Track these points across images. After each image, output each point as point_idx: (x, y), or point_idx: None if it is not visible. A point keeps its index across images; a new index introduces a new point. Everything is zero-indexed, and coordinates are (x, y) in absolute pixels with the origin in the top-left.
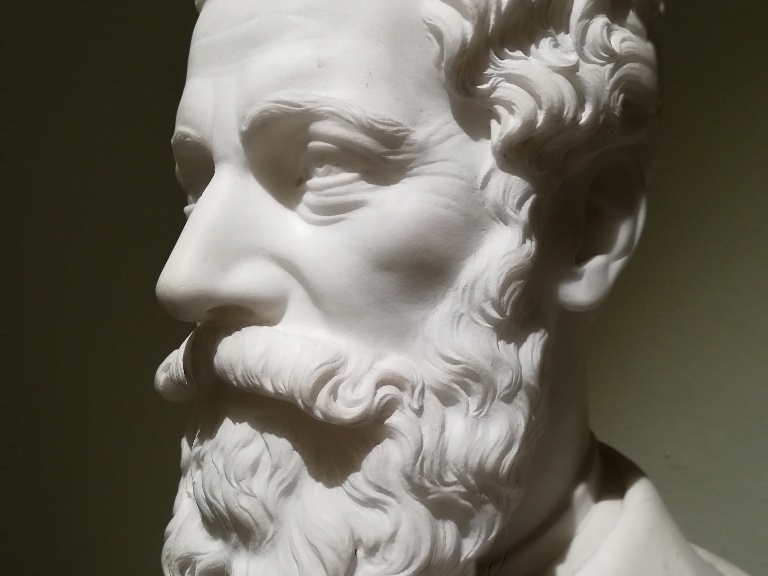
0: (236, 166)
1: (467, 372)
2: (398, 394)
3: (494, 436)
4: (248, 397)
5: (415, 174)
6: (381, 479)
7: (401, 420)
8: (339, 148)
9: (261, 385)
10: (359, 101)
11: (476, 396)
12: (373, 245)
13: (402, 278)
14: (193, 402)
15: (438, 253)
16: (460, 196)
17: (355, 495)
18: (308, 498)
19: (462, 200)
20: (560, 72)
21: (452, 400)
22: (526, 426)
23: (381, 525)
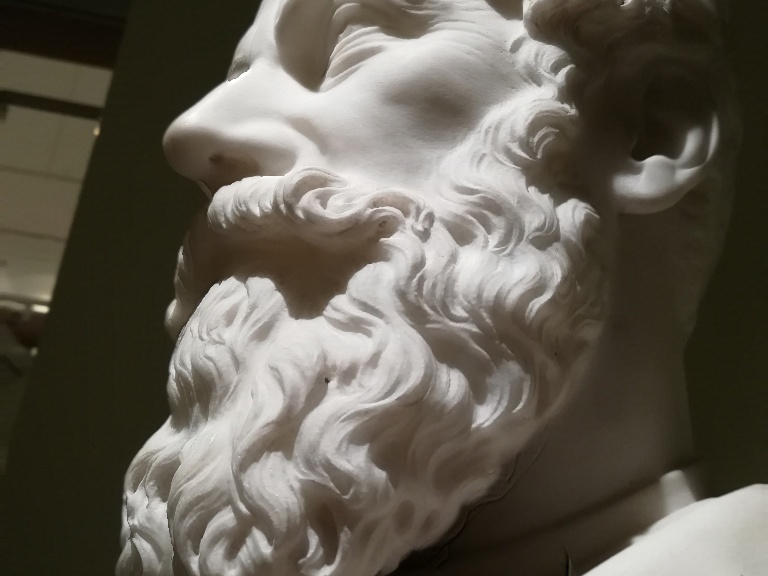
0: (267, 59)
1: (486, 202)
2: (399, 214)
3: (519, 274)
4: (240, 254)
5: (437, 29)
6: (368, 295)
7: (400, 238)
8: (359, 4)
9: (247, 210)
10: None
11: (497, 231)
12: (385, 79)
13: (415, 112)
14: None
15: (457, 91)
16: (485, 49)
17: (335, 317)
18: (282, 335)
19: (487, 53)
20: None
21: (468, 237)
22: (564, 278)
23: (362, 347)
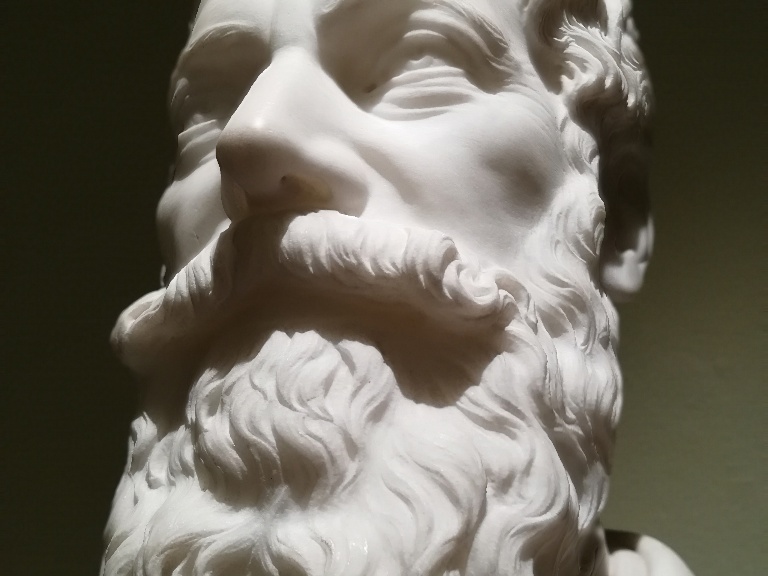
0: (308, 51)
1: (574, 297)
2: (515, 301)
3: (603, 376)
4: (313, 302)
5: (512, 90)
6: (509, 393)
7: (522, 330)
8: (446, 38)
9: (359, 264)
10: None
11: (582, 328)
12: (482, 138)
13: (507, 183)
14: (165, 365)
15: (539, 168)
16: (550, 125)
17: (477, 412)
18: (408, 421)
19: (551, 130)
20: (613, 55)
21: (557, 329)
22: None
23: (513, 451)
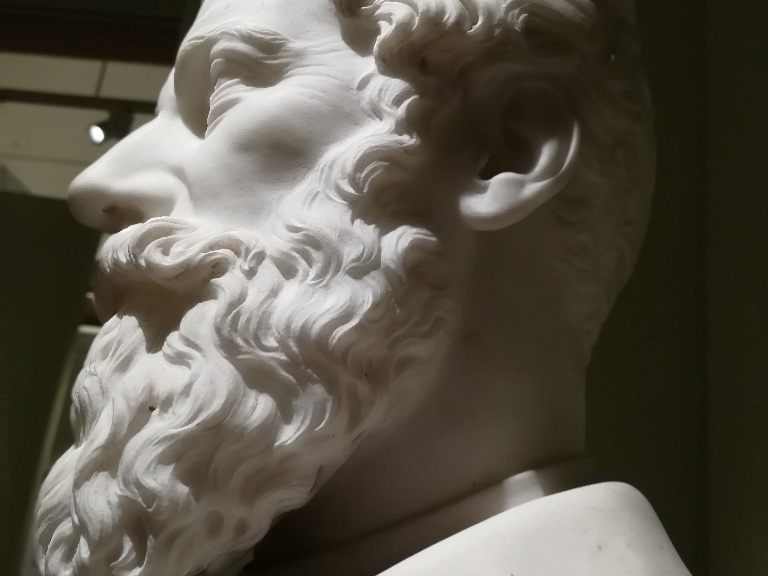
0: (168, 111)
1: (308, 239)
2: (231, 255)
3: (328, 304)
4: (126, 294)
5: (290, 75)
6: (191, 332)
7: (227, 278)
8: (225, 59)
9: (117, 258)
10: (245, 20)
11: (316, 264)
12: (236, 129)
13: (260, 158)
14: None
15: (297, 134)
16: (330, 91)
17: (167, 352)
18: None
19: (332, 94)
20: None
21: (293, 271)
22: (375, 305)
23: (181, 378)
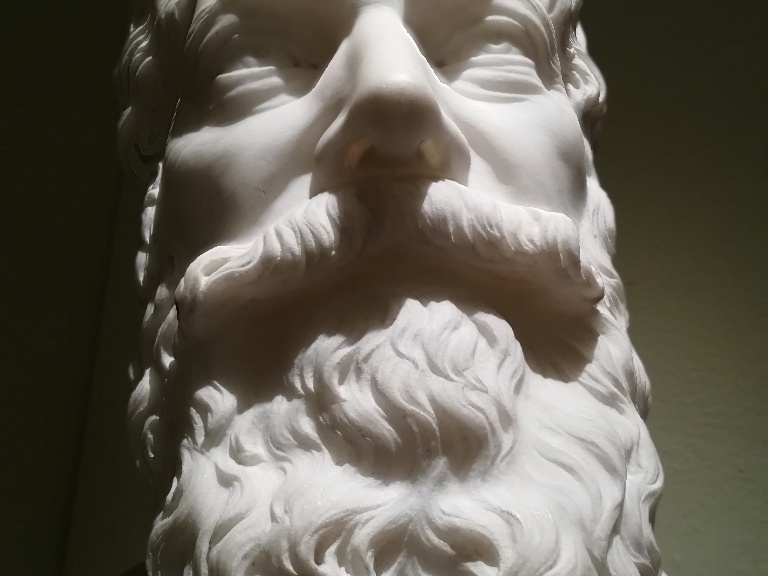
0: (399, 14)
1: (618, 288)
2: None
3: (638, 361)
4: (440, 272)
5: (559, 89)
6: (616, 371)
7: (607, 314)
8: (525, 29)
9: (502, 237)
10: None
11: (622, 317)
12: (558, 131)
13: (571, 176)
14: (232, 330)
15: None
16: None
17: (598, 388)
18: (546, 394)
19: None
20: None
21: None
22: None
23: (627, 425)
